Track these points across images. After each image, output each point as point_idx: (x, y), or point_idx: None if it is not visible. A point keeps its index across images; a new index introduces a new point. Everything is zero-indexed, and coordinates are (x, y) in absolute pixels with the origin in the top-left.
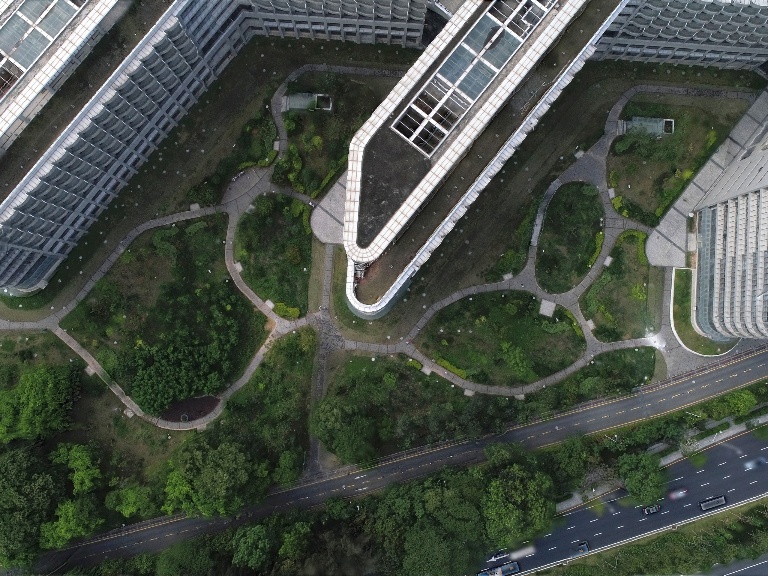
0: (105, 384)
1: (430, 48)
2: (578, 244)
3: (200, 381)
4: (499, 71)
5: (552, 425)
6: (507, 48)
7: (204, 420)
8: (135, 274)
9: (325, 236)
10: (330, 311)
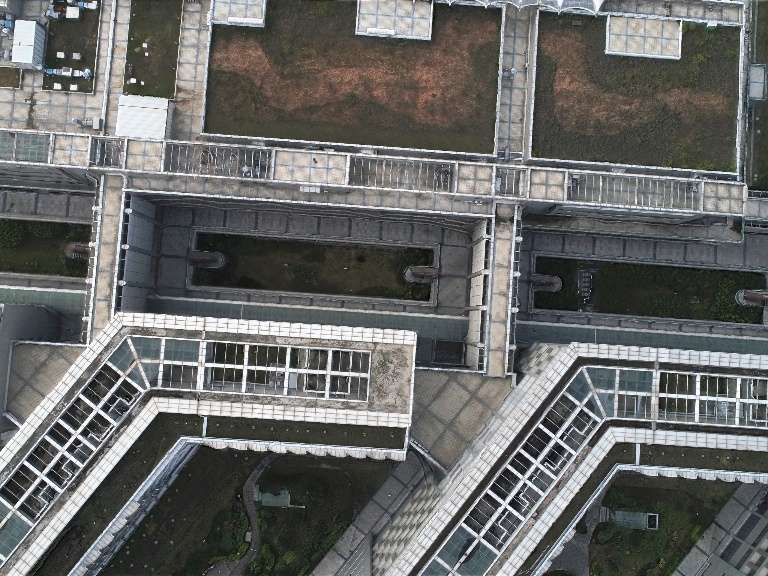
0: None
1: (402, 563)
2: None
3: None
4: None
5: None
6: (482, 562)
7: None
8: None
9: None
10: None
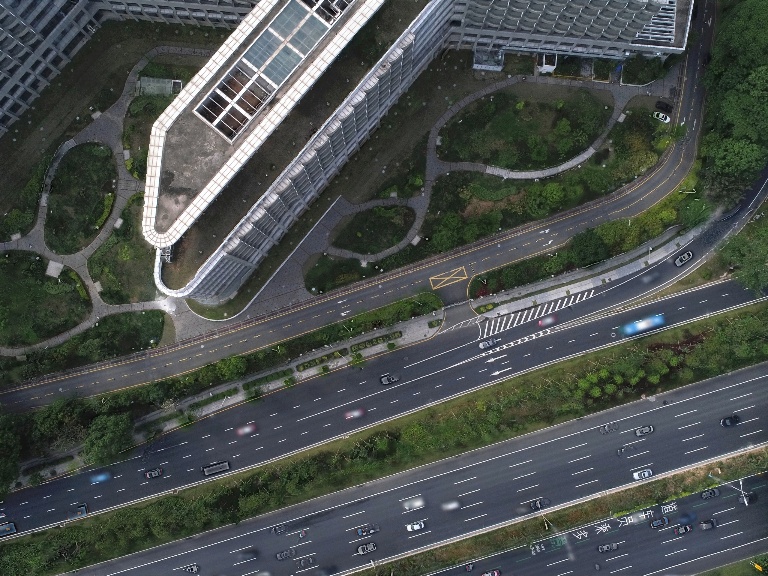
0: None
1: None
2: (86, 205)
3: None
4: None
5: (56, 387)
6: None
7: None
8: None
9: None
10: None
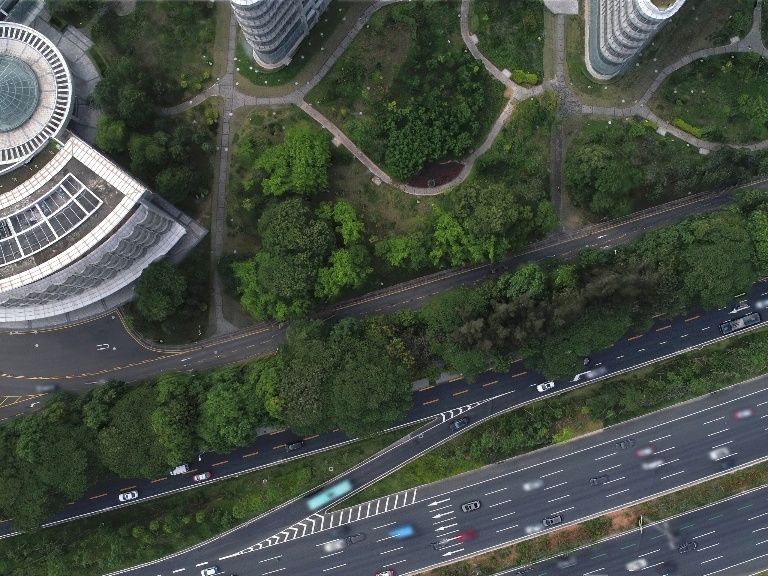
0: (352, 154)
1: None
2: None
3: (452, 140)
4: None
5: None
6: None
7: (450, 185)
8: (376, 47)
9: (556, 7)
10: (565, 78)
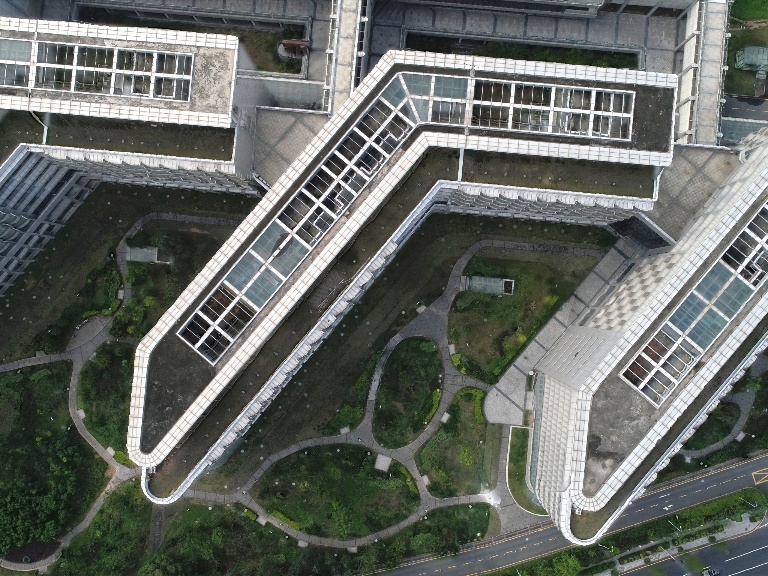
0: None
1: (218, 255)
2: (415, 401)
3: (37, 530)
4: (285, 280)
5: None
6: (295, 256)
7: (45, 562)
8: None
9: None
10: None
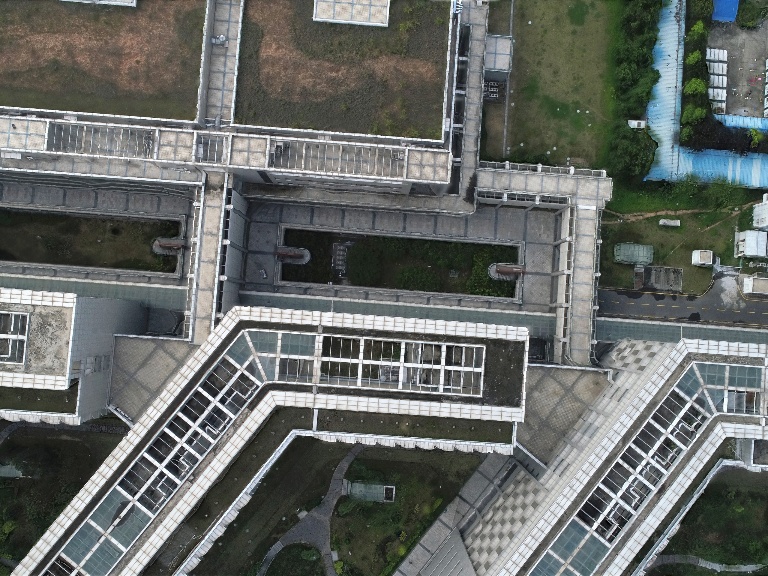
0: None
1: (54, 526)
2: None
3: None
4: (126, 551)
5: None
6: (136, 525)
7: None
8: None
9: None
10: None
